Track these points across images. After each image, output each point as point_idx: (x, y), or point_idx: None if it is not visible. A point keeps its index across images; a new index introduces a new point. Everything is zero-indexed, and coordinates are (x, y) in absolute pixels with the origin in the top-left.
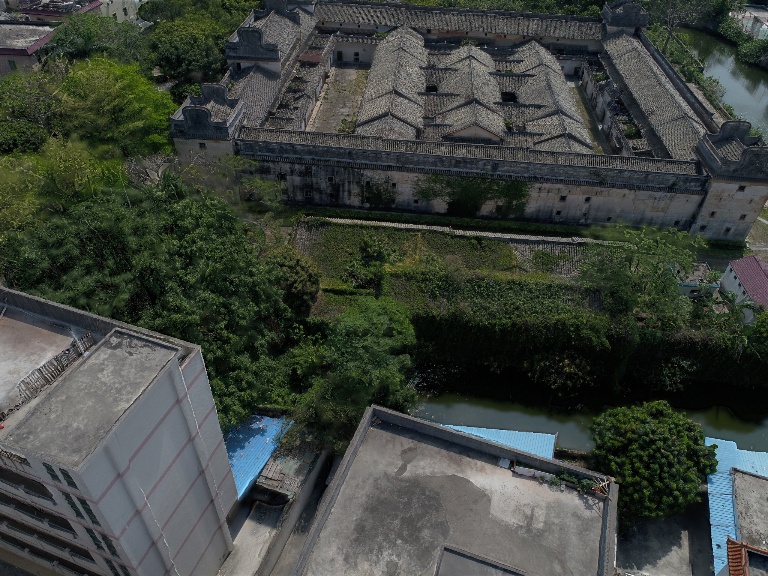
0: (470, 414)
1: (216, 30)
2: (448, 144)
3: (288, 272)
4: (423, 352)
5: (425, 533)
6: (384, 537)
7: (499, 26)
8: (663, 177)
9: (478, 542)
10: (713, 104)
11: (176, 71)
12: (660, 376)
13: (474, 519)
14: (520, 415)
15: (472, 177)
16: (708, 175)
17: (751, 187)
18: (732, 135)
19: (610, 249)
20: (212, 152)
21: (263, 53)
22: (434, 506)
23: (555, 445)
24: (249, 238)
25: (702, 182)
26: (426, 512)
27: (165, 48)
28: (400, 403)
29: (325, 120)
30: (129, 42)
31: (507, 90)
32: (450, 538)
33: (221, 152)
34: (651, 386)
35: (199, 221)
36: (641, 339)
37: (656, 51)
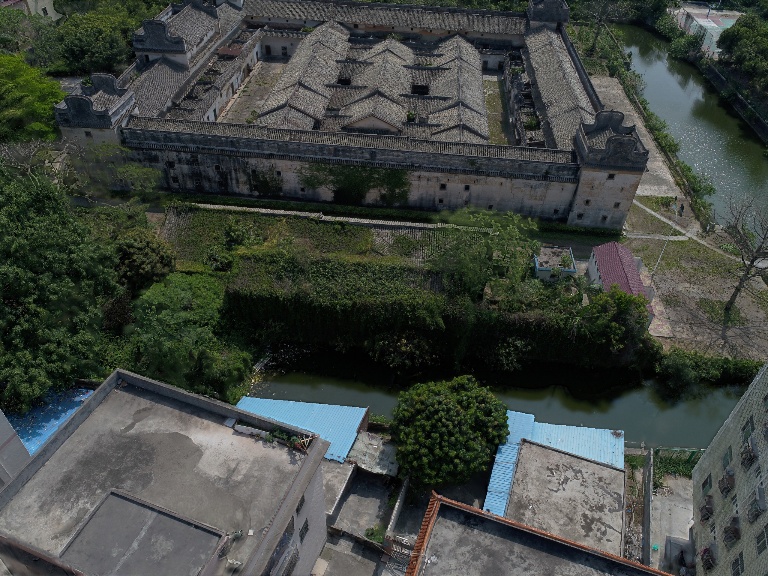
0: (311, 392)
1: (126, 23)
2: (331, 133)
3: (136, 253)
4: (274, 332)
5: (127, 484)
6: (86, 487)
7: (424, 21)
8: (536, 165)
9: (173, 492)
10: (630, 98)
11: (80, 62)
12: (498, 356)
13: (178, 472)
14: (359, 393)
15: (352, 165)
16: (579, 164)
17: (620, 175)
18: (607, 125)
19: (469, 234)
20: (98, 140)
21: (169, 45)
22: (145, 460)
23: (363, 418)
24: (130, 224)
25: (574, 170)
26: (135, 465)
27: (69, 40)
28: (217, 377)
29: (238, 112)
30: (41, 35)
31: (421, 83)
32: (148, 488)
33: (107, 140)
34: (491, 366)
35: (13, 200)
36: (478, 319)
37: (571, 45)
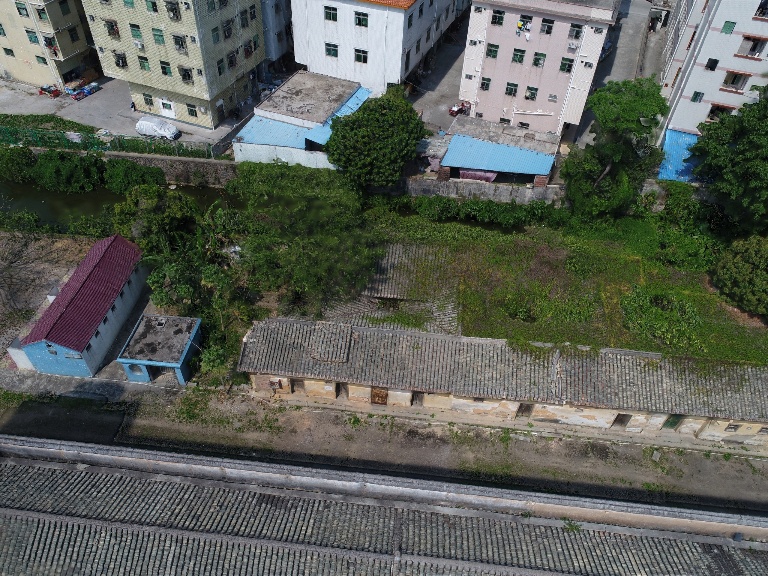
0: None
1: None
2: None
3: (762, 241)
4: None
5: None
6: None
7: None
8: None
9: None
10: None
11: None
12: None
13: None
14: None
15: None
16: None
17: None
18: None
19: None
20: None
21: None
22: None
23: None
24: None
25: None
26: None
27: None
28: None
29: None
30: None
31: None
32: None
33: None
34: None
35: None
36: None
37: None
